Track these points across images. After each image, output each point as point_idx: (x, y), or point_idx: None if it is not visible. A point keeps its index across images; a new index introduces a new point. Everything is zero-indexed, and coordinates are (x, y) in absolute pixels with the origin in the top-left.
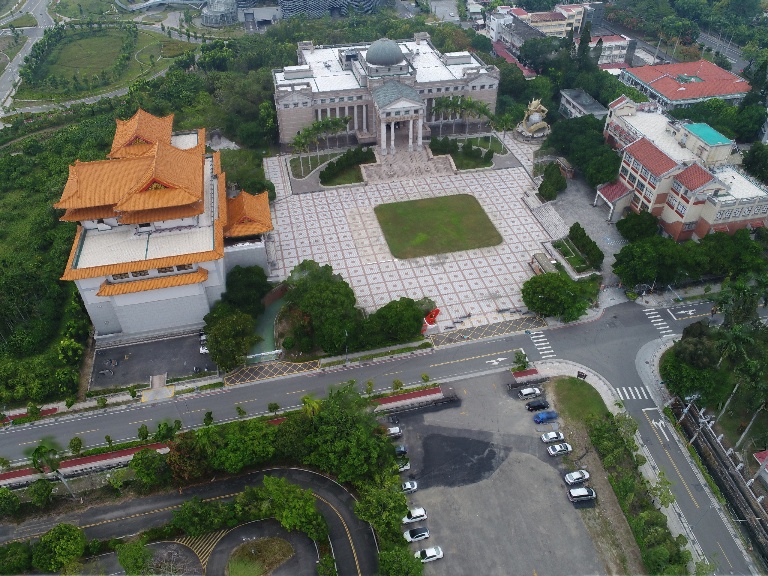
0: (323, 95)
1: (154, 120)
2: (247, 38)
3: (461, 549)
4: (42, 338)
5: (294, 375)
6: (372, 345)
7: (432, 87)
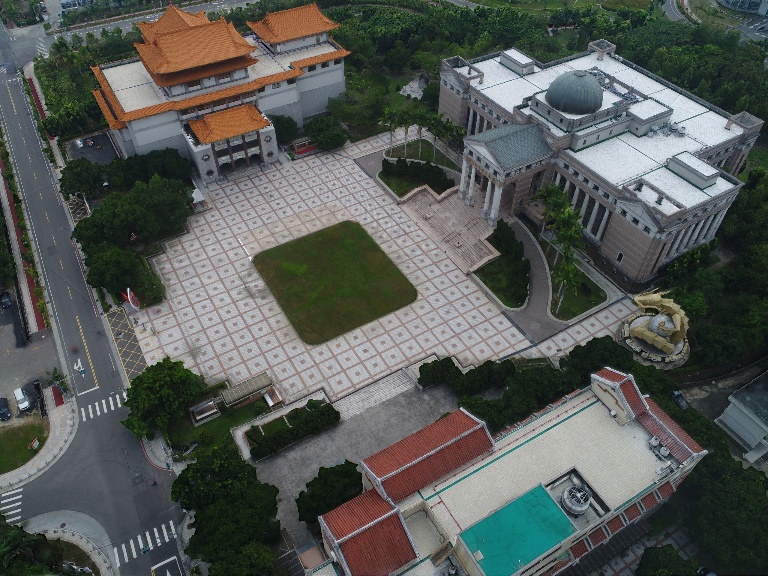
0: (477, 94)
1: (315, 19)
2: (670, 24)
3: None
4: None
5: None
6: None
7: (579, 170)
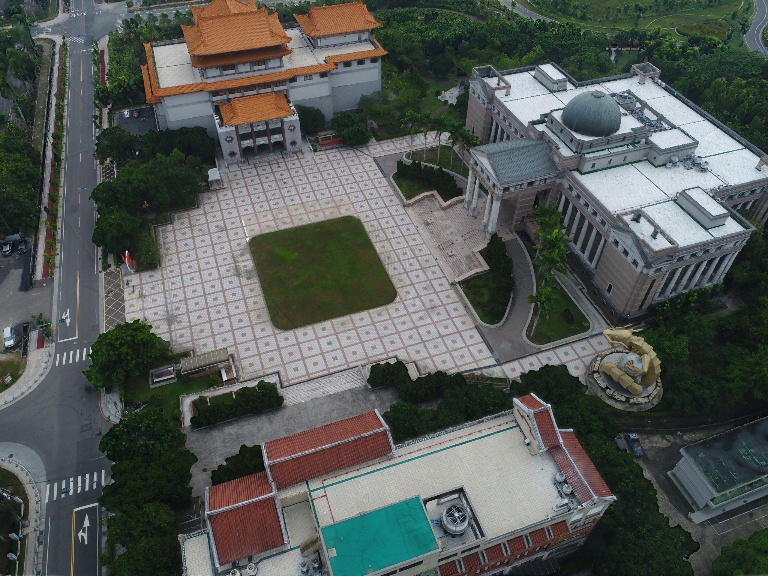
0: (500, 105)
1: (358, 17)
2: (742, 54)
3: None
4: None
5: None
6: None
7: (581, 193)
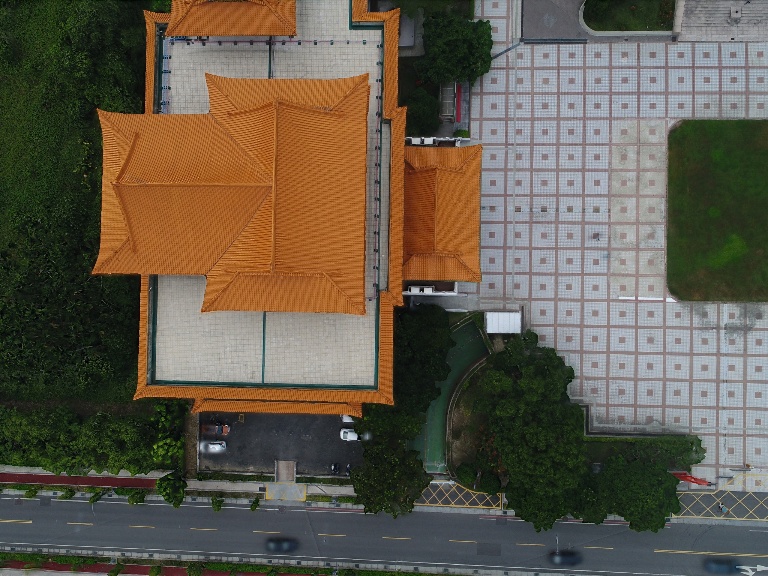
0: None
1: None
2: None
3: None
4: (124, 363)
5: (464, 511)
6: (585, 522)
7: None
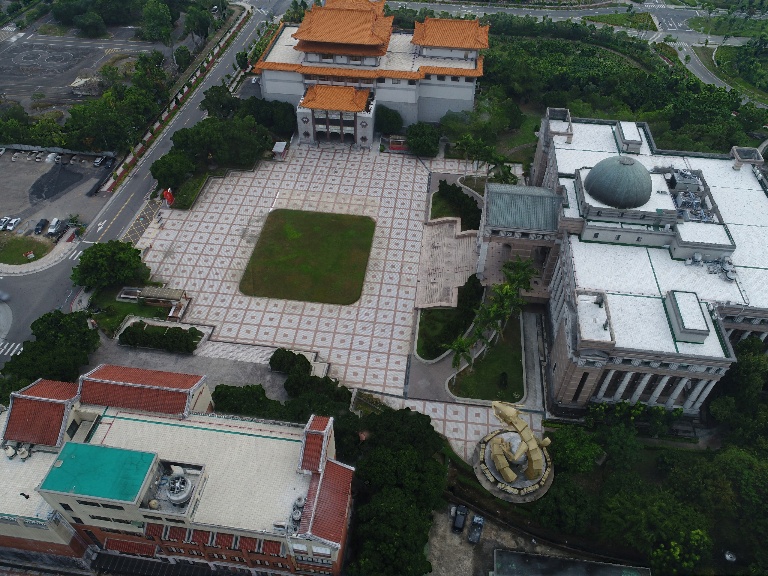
0: None
1: (470, 35)
2: None
3: (8, 168)
4: None
5: None
6: None
7: None
